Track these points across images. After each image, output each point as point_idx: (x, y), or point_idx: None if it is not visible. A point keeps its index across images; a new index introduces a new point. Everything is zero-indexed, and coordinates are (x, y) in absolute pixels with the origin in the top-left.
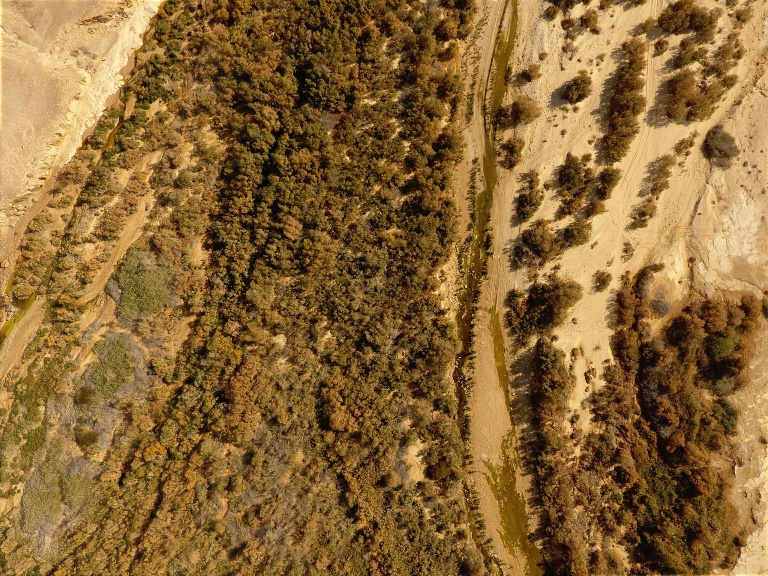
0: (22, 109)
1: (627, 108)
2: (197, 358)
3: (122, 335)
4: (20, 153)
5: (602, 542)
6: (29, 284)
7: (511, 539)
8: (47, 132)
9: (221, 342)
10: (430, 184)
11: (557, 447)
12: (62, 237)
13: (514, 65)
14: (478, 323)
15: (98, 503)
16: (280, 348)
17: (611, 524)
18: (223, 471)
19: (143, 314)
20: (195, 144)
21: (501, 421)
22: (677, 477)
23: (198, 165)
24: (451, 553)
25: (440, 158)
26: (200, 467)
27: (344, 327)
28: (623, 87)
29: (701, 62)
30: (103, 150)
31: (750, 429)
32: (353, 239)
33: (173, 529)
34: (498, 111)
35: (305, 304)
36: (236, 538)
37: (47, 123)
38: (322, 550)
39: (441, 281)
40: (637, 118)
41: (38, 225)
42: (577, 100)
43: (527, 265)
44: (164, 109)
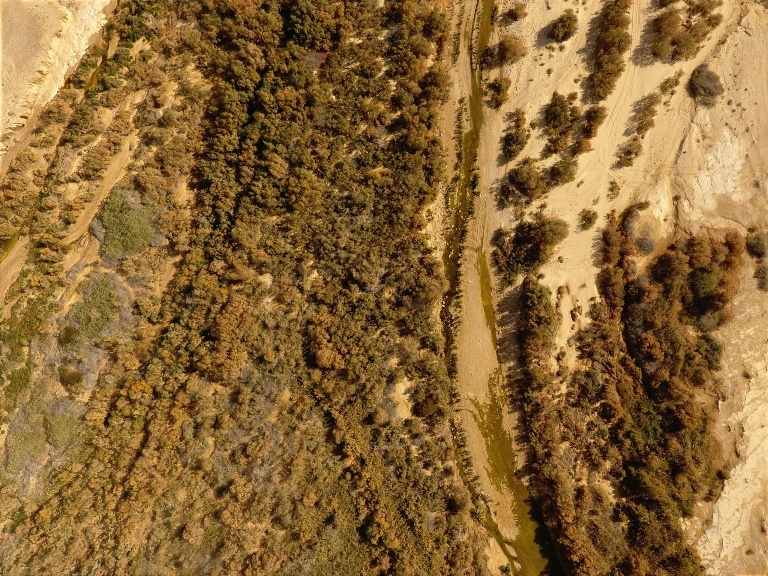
0: (2, 46)
1: (613, 45)
2: (183, 297)
3: (106, 275)
4: (1, 91)
5: (588, 477)
6: (11, 224)
7: (498, 476)
8: (28, 69)
9: (207, 280)
10: (416, 121)
11: (543, 383)
12: (45, 177)
13: (500, 4)
14: (465, 262)
15: (83, 443)
16: (266, 287)
17: (597, 458)
18: (210, 410)
19: (128, 253)
20: (179, 83)
21: (488, 359)
22: (662, 412)
23: (182, 103)
24: (438, 489)
25: (426, 96)
26: (186, 406)
27: (330, 265)
28: (609, 24)
29: (686, 1)
30: (86, 89)
31: (734, 364)
32: (339, 177)
33: (159, 468)
34: (484, 51)
35: (291, 243)
36: (223, 476)
37: (28, 60)
38: (309, 487)
39: (428, 220)
40: (623, 56)
41: (20, 164)
42: (563, 38)
43: (513, 204)
44: (148, 48)
